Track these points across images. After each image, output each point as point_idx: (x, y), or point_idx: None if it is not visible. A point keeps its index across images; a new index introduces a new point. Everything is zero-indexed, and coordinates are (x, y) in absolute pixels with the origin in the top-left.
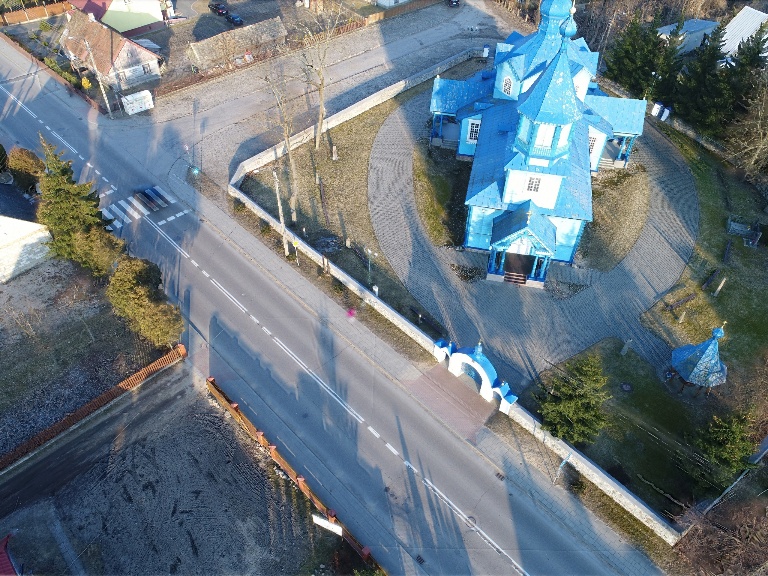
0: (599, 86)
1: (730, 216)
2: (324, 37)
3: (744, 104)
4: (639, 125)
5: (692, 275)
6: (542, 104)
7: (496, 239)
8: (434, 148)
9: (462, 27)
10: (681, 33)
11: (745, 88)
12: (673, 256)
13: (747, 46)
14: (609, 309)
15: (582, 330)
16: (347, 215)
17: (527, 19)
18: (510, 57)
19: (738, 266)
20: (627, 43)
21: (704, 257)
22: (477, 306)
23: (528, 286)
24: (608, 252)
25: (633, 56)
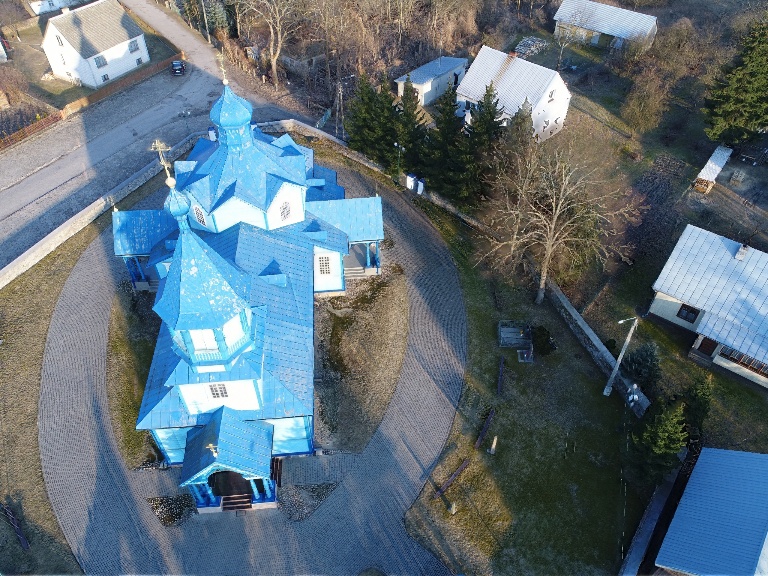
0: (347, 159)
1: (499, 323)
2: (2, 146)
3: (493, 174)
4: (378, 228)
5: (463, 426)
6: (180, 305)
7: (184, 477)
8: (140, 295)
9: (188, 102)
10: (428, 79)
11: (487, 160)
12: (440, 400)
13: (479, 112)
14: (364, 517)
15: (329, 569)
16: (3, 445)
17: (264, 80)
18: (193, 180)
19: (514, 396)
20: (362, 110)
21: (476, 392)
22: (184, 570)
23: (257, 509)
24: (362, 416)
25: (371, 125)
